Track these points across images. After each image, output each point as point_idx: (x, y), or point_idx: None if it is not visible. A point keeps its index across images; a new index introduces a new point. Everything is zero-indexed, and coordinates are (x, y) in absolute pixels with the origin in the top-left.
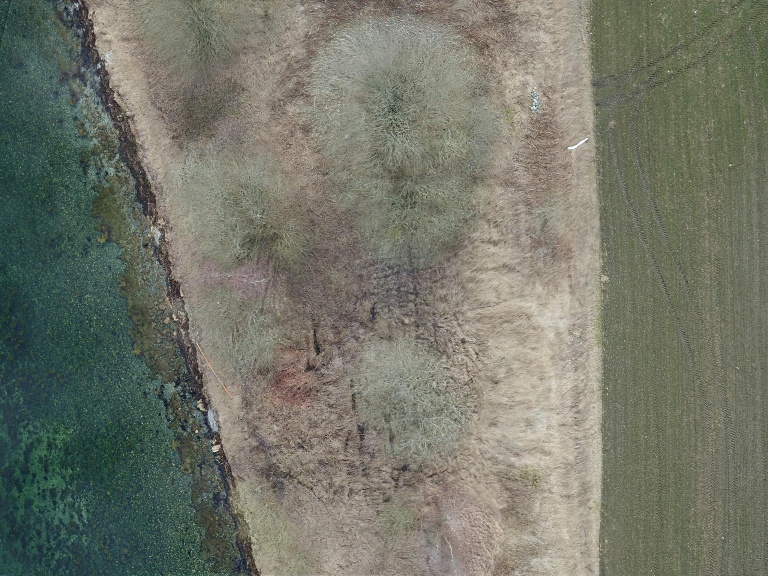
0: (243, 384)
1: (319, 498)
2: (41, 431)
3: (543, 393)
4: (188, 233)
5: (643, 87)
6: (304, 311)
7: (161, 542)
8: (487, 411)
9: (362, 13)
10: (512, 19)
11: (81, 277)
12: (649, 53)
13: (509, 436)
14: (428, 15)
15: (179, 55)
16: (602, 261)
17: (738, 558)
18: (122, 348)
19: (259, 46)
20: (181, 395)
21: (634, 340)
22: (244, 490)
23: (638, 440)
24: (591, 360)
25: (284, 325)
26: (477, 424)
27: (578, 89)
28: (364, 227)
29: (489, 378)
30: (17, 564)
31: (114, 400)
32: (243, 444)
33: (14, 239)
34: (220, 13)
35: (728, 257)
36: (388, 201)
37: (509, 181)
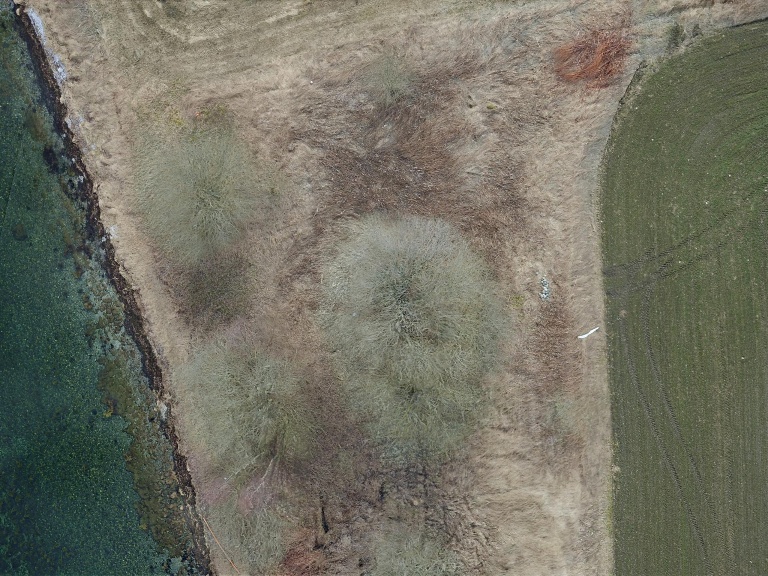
0: (251, 560)
1: None
2: None
3: None
4: (194, 408)
5: (654, 277)
6: (312, 488)
7: None
8: None
9: (369, 192)
10: (521, 204)
11: (87, 450)
12: (660, 243)
13: None
14: (436, 195)
15: (185, 230)
16: (613, 451)
17: None
18: (128, 521)
19: (265, 222)
20: (188, 570)
21: (646, 531)
22: None
23: None
24: (603, 550)
25: (292, 502)
26: None
27: (588, 277)
28: (372, 406)
29: (499, 563)
30: None
31: (120, 574)
32: None
33: (19, 411)
34: (226, 188)
35: (741, 450)
36: (397, 384)
37: (519, 368)
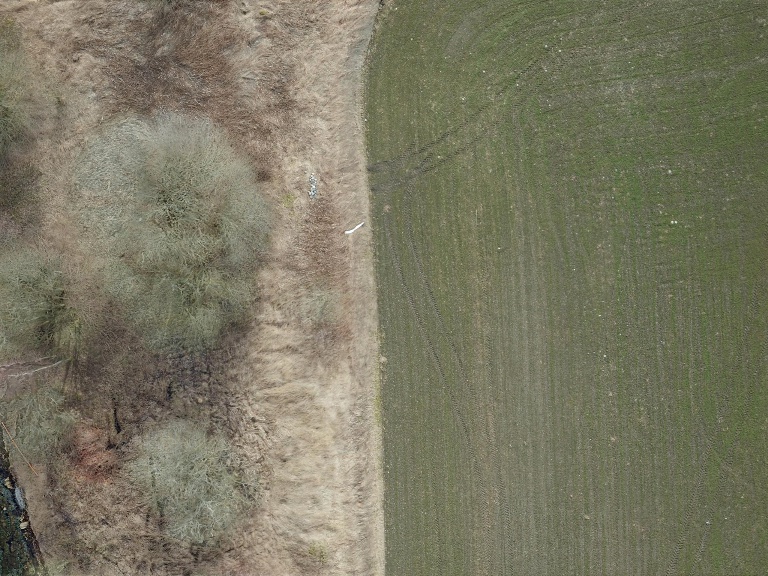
0: (48, 462)
1: (124, 573)
2: None
3: (327, 471)
4: None
5: (415, 172)
6: (105, 390)
7: None
8: (278, 488)
9: (152, 99)
10: (292, 105)
11: None
12: (420, 139)
13: (298, 513)
14: (215, 100)
15: None
16: (380, 342)
17: None
18: None
19: (54, 131)
20: None
21: (412, 419)
22: (52, 566)
23: (418, 517)
24: (372, 439)
25: (86, 404)
26: (269, 501)
27: (354, 174)
28: (159, 308)
29: (278, 456)
30: None
31: None
32: (49, 521)
33: None
34: (16, 99)
35: (499, 338)
36: None
37: (290, 265)
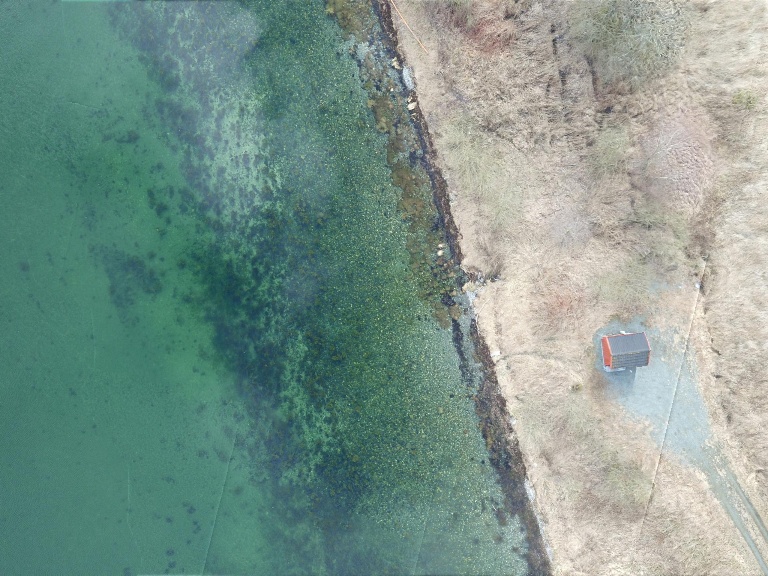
0: (439, 38)
1: (519, 149)
2: (232, 98)
3: (756, 14)
4: None
5: None
6: None
7: (357, 204)
8: (695, 42)
9: None
10: None
11: None
12: None
13: (720, 62)
14: None
15: None
16: None
17: None
18: (314, 10)
19: None
20: (375, 54)
21: None
22: (442, 146)
23: None
24: None
25: None
26: (684, 57)
27: None
28: None
29: (698, 7)
30: (210, 234)
31: (306, 63)
32: (440, 99)
33: None
34: None
35: None
36: None
37: None
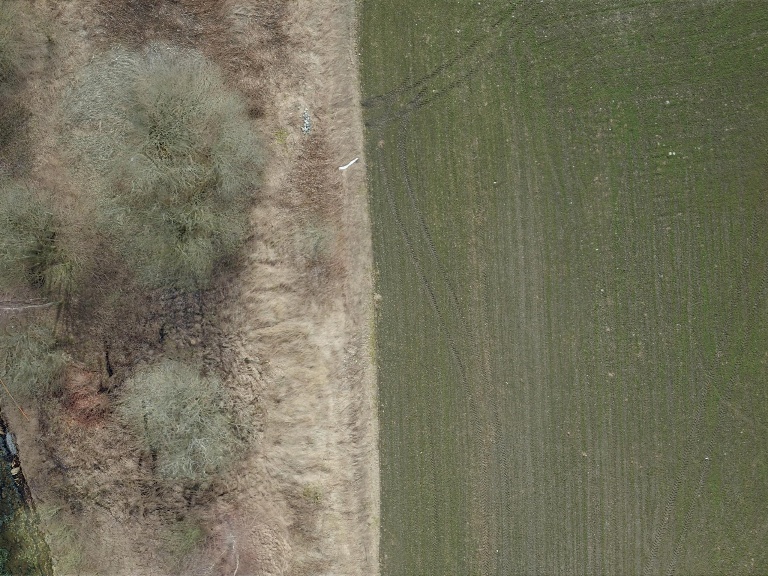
0: (39, 407)
1: (116, 518)
2: None
3: (322, 411)
4: None
5: (410, 107)
6: (96, 333)
7: None
8: (272, 430)
9: (143, 37)
10: (285, 41)
11: None
12: (415, 73)
13: (292, 454)
14: (207, 38)
15: None
16: (375, 280)
17: (512, 571)
18: None
19: (45, 71)
20: None
21: (407, 357)
22: (43, 512)
23: (413, 456)
24: (366, 378)
25: (77, 348)
26: (263, 443)
27: (348, 110)
28: (151, 249)
29: (272, 397)
30: None
31: None
32: (41, 466)
33: None
34: (6, 39)
35: (495, 274)
36: None
37: (283, 202)
